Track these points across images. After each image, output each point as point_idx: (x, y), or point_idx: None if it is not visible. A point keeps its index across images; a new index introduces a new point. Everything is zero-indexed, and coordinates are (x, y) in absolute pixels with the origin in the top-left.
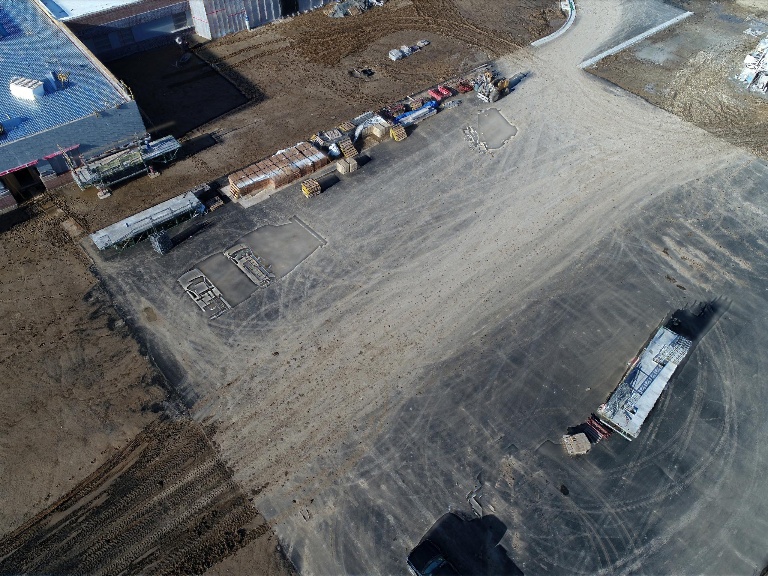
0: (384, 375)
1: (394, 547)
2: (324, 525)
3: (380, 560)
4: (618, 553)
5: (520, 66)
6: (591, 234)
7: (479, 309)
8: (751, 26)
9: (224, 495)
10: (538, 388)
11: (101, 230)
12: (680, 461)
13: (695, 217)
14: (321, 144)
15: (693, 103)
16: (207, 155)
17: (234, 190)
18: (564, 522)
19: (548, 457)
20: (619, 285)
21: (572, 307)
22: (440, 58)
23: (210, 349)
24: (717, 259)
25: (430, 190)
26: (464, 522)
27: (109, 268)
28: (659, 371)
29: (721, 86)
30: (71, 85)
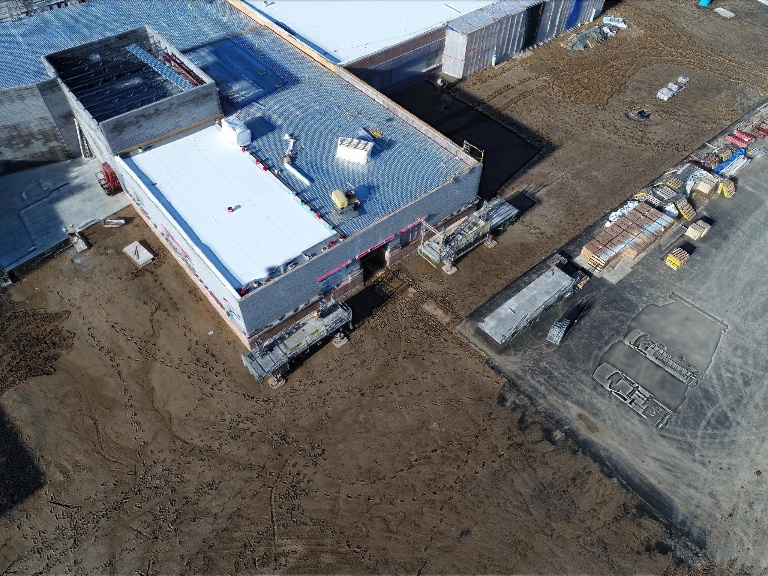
0: None
1: None
2: None
3: None
4: None
5: None
6: None
7: None
8: None
9: None
10: None
11: (487, 318)
12: None
13: None
14: (656, 204)
15: None
16: (534, 218)
17: (596, 263)
18: None
19: None
20: None
21: None
22: (711, 96)
23: (681, 468)
24: None
25: None
26: None
27: (509, 363)
28: None
29: None
30: (392, 143)
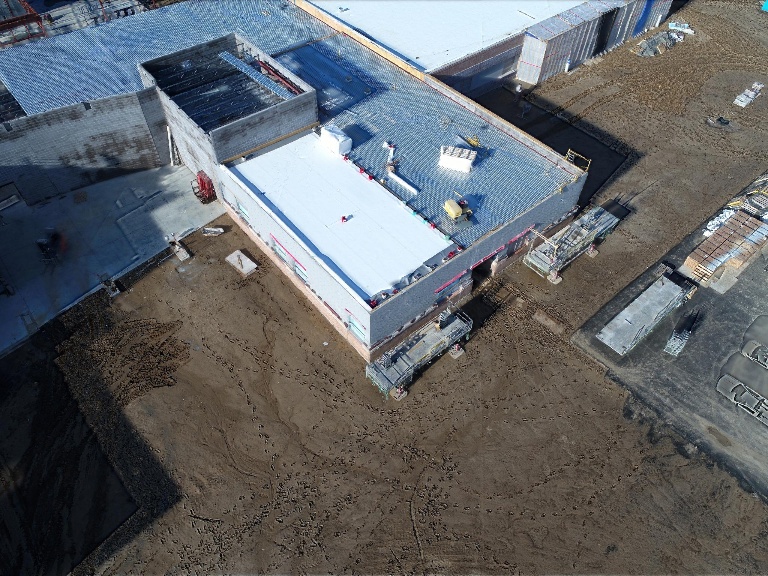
0: None
1: None
2: None
3: None
4: None
5: None
6: None
7: None
8: None
9: None
10: None
11: (605, 329)
12: None
13: None
14: (753, 213)
15: None
16: (630, 227)
17: (703, 273)
18: None
19: None
20: None
21: None
22: None
23: None
24: None
25: None
26: None
27: (630, 375)
28: None
29: None
30: (491, 152)
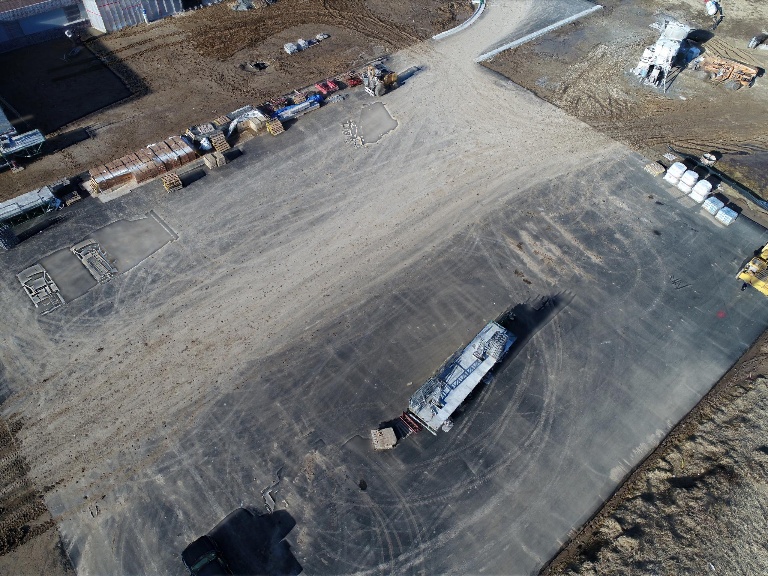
0: (205, 370)
1: (177, 543)
2: (110, 521)
3: (160, 556)
4: (403, 547)
5: (416, 60)
6: (448, 228)
7: (317, 304)
8: (659, 20)
9: (15, 492)
10: (359, 383)
11: None
12: (486, 455)
13: (557, 211)
14: (193, 138)
15: (582, 97)
16: (76, 149)
17: (93, 185)
18: (355, 517)
19: (354, 452)
20: (465, 279)
21: (412, 302)
22: (337, 52)
23: (34, 345)
24: (570, 253)
25: (295, 184)
26: (254, 517)
27: None
28: (477, 365)
29: (614, 80)
30: None
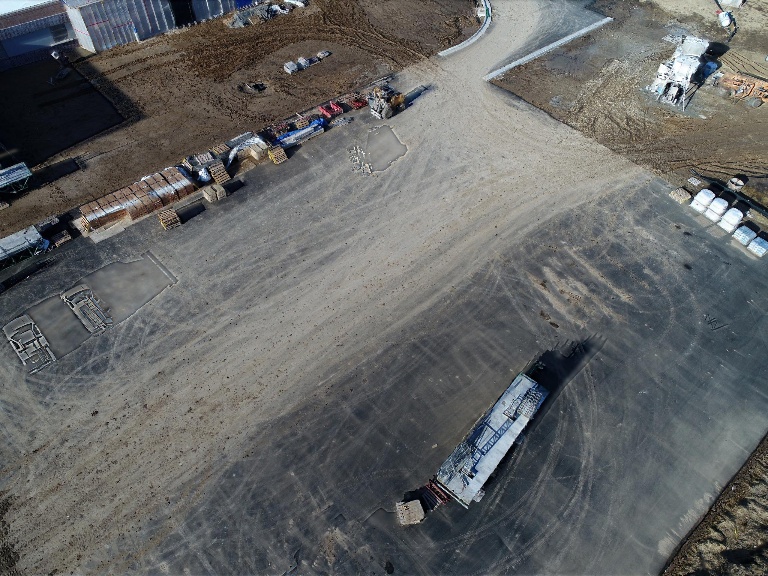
0: (211, 436)
1: None
2: None
3: None
4: None
5: (422, 78)
6: (466, 266)
7: (330, 355)
8: (671, 32)
9: None
10: (380, 446)
11: None
12: (523, 528)
13: (581, 244)
14: (190, 169)
15: (598, 117)
16: (66, 183)
17: (84, 223)
18: None
19: (377, 528)
20: (488, 324)
21: (432, 350)
22: (339, 70)
23: (22, 410)
24: (597, 292)
25: (301, 219)
26: None
27: None
28: (509, 426)
29: (630, 98)
30: None
